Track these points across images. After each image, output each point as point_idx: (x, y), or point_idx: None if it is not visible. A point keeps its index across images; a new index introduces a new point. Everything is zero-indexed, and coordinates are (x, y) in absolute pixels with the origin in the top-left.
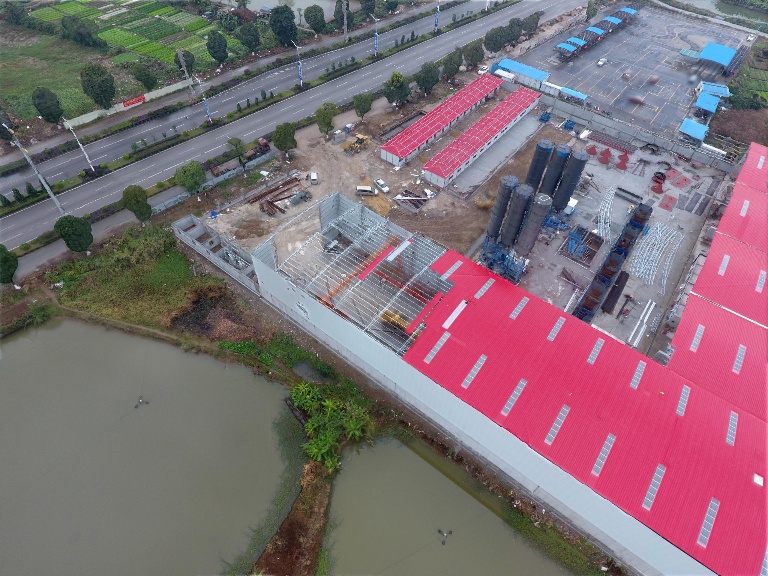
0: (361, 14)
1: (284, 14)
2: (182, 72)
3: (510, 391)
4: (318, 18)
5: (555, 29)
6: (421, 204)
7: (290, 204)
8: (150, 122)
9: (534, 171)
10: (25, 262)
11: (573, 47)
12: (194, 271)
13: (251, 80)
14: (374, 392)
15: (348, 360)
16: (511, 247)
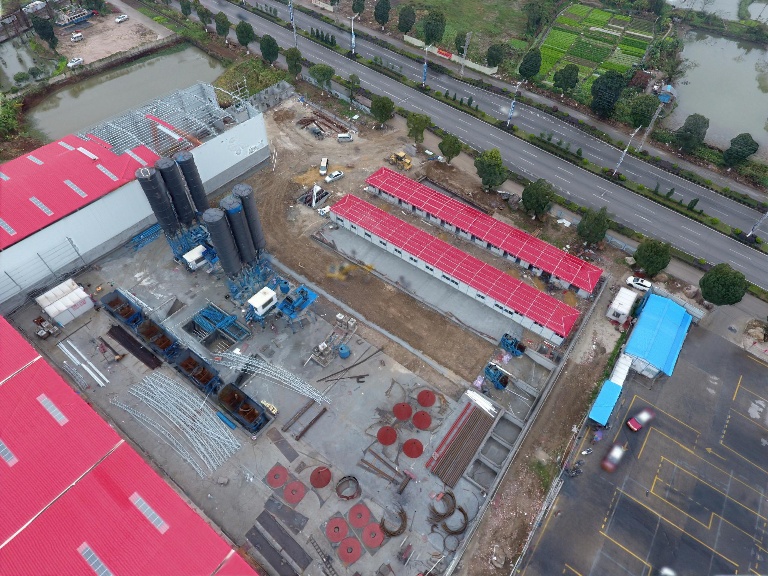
0: None
1: (607, 79)
2: None
3: (7, 173)
4: (638, 109)
5: None
6: (305, 202)
7: None
8: (422, 65)
9: None
10: None
11: None
12: None
13: (510, 100)
14: None
15: None
16: None
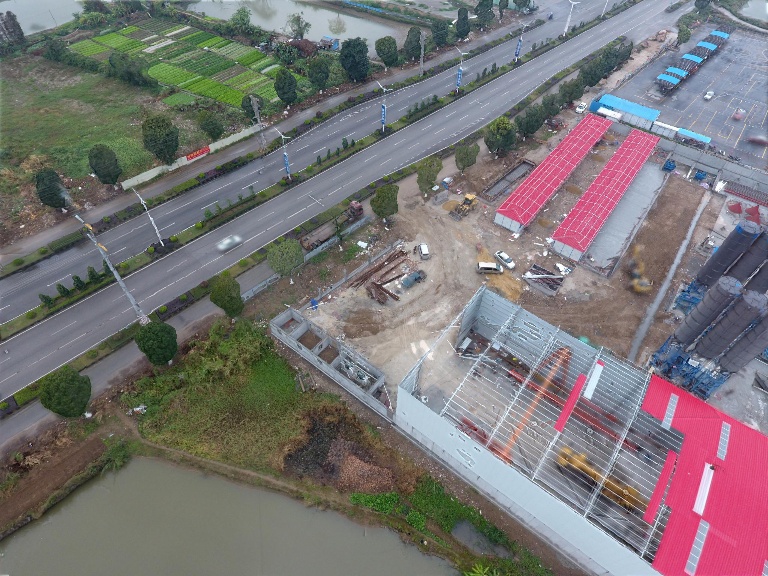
0: (429, 43)
1: (357, 48)
2: (249, 117)
3: None
4: (392, 51)
5: (644, 56)
6: (558, 284)
7: (402, 287)
8: (219, 179)
9: (726, 257)
10: (93, 375)
11: (675, 79)
12: (301, 384)
13: (324, 124)
14: (569, 574)
15: (525, 523)
16: (712, 359)
